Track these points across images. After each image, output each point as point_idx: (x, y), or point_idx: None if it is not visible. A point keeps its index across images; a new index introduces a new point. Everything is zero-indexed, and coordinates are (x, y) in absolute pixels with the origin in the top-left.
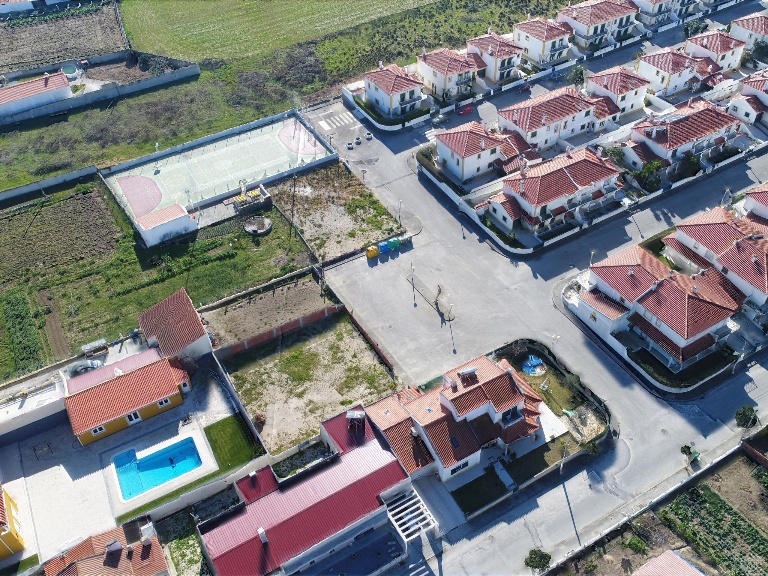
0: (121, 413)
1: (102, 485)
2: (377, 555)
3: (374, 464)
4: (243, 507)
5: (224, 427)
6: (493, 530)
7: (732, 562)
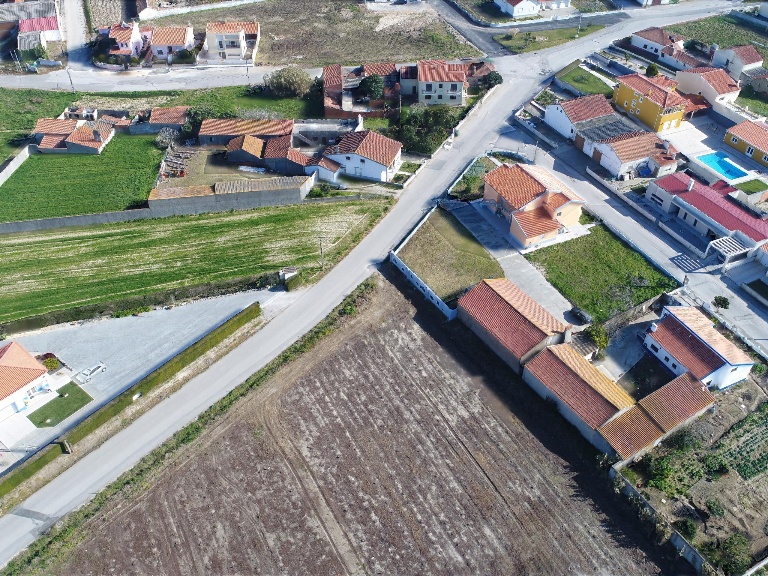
0: (749, 141)
1: (702, 150)
2: (699, 243)
3: (760, 229)
4: (707, 184)
5: (762, 185)
6: (739, 298)
7: (766, 421)
